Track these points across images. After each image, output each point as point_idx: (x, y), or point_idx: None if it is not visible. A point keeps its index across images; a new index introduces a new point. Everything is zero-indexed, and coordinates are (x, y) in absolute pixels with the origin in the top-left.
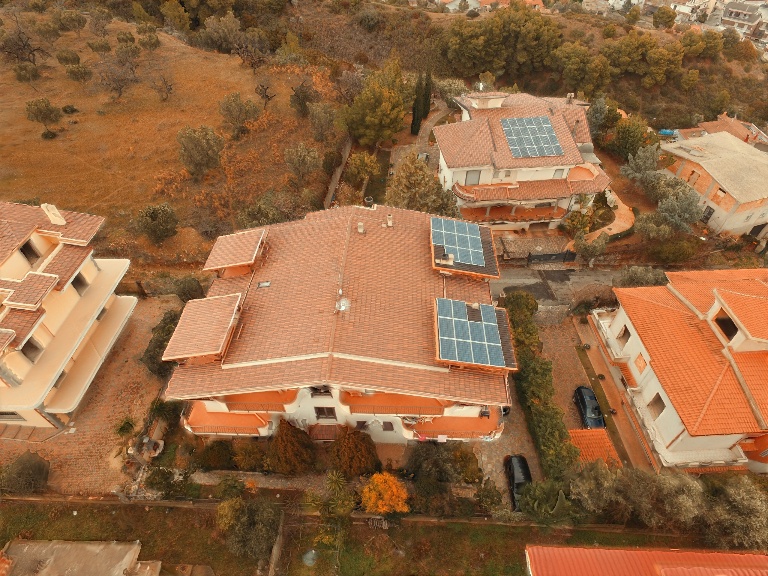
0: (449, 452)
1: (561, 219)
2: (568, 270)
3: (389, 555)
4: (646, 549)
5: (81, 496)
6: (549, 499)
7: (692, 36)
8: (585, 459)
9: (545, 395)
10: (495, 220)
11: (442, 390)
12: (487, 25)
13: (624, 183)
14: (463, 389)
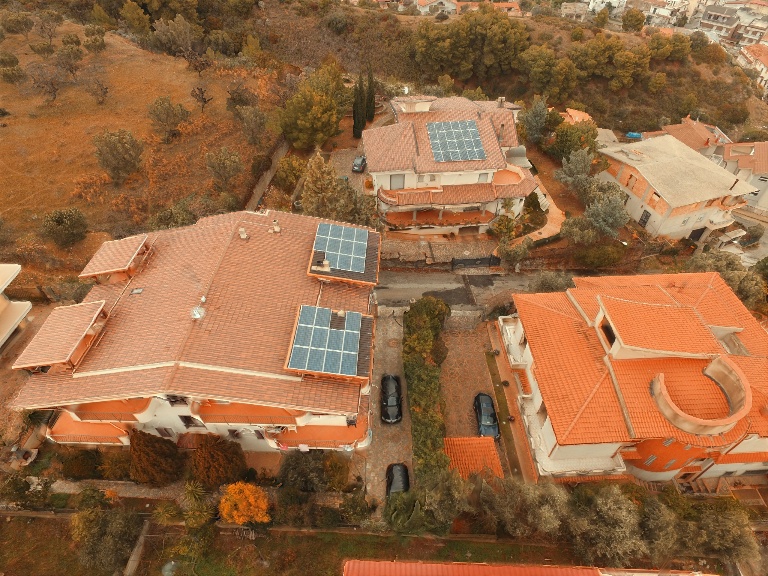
0: (318, 461)
1: (488, 223)
2: (493, 275)
3: (252, 566)
4: (520, 559)
5: None
6: (409, 509)
7: (659, 39)
8: (466, 468)
9: (427, 403)
10: (421, 224)
11: (289, 399)
12: (453, 28)
13: (562, 187)
14: (313, 398)
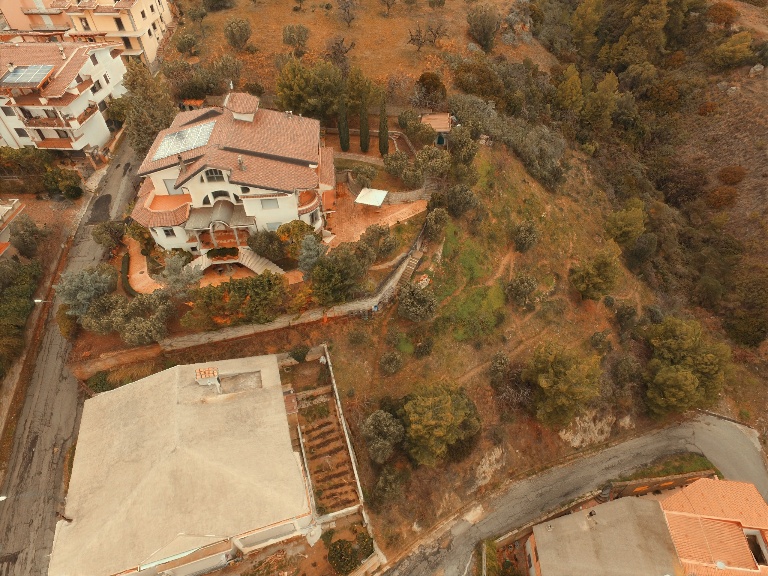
0: None
1: None
2: None
3: None
4: None
5: None
6: None
7: None
8: None
9: None
10: None
11: None
12: None
13: None
14: None
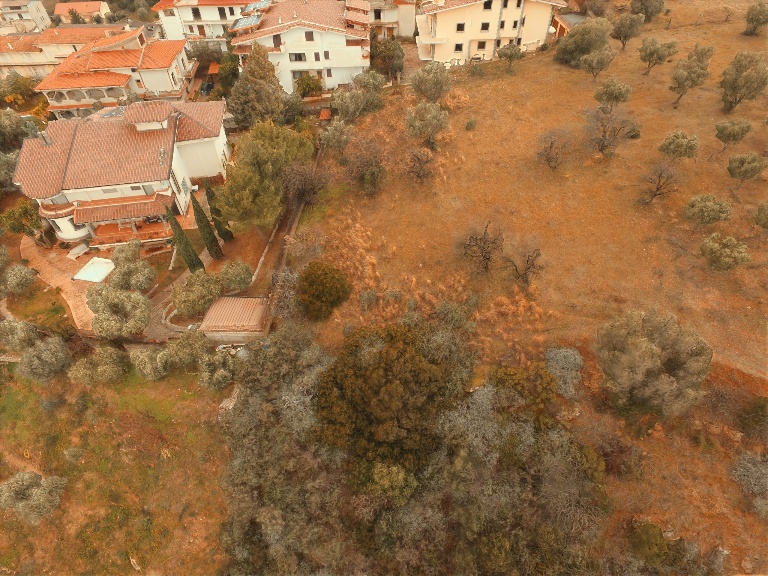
0: None
1: None
2: None
3: None
4: None
5: (404, 43)
6: None
7: None
8: None
9: None
10: None
11: None
12: None
13: None
14: None
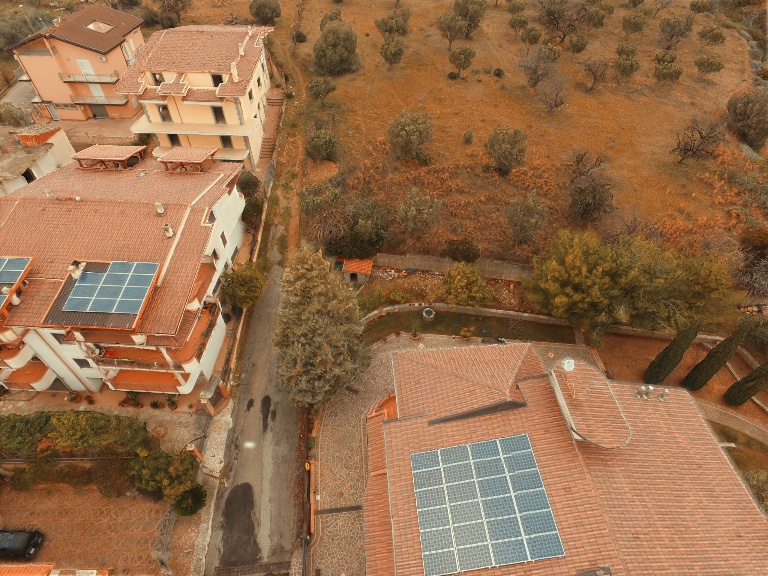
0: None
1: None
2: None
3: None
4: None
5: None
6: None
7: None
8: None
9: None
10: None
11: None
12: None
13: None
14: None
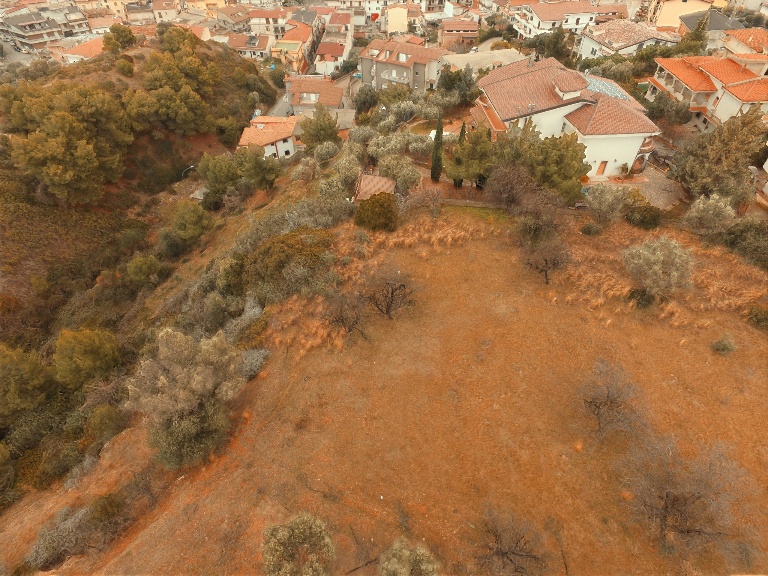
0: None
1: None
2: None
3: None
4: None
5: None
6: None
7: (173, 38)
8: None
9: None
10: None
11: None
12: (61, 126)
13: None
14: None
